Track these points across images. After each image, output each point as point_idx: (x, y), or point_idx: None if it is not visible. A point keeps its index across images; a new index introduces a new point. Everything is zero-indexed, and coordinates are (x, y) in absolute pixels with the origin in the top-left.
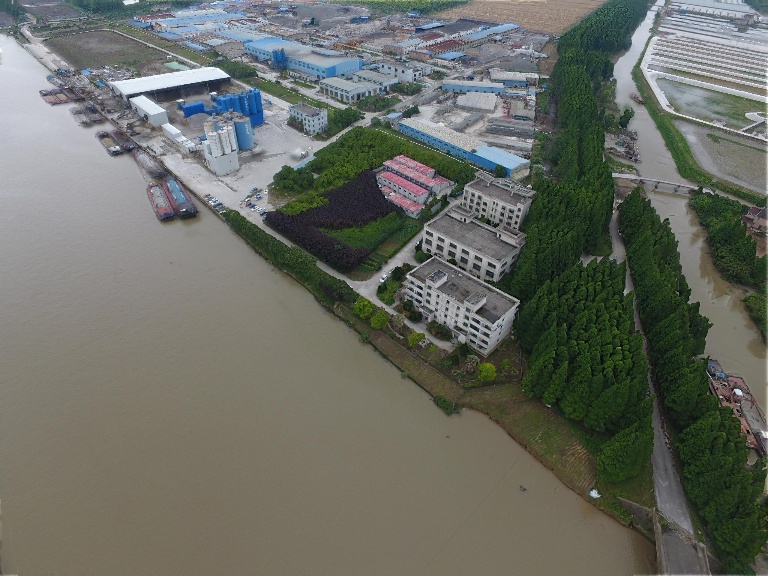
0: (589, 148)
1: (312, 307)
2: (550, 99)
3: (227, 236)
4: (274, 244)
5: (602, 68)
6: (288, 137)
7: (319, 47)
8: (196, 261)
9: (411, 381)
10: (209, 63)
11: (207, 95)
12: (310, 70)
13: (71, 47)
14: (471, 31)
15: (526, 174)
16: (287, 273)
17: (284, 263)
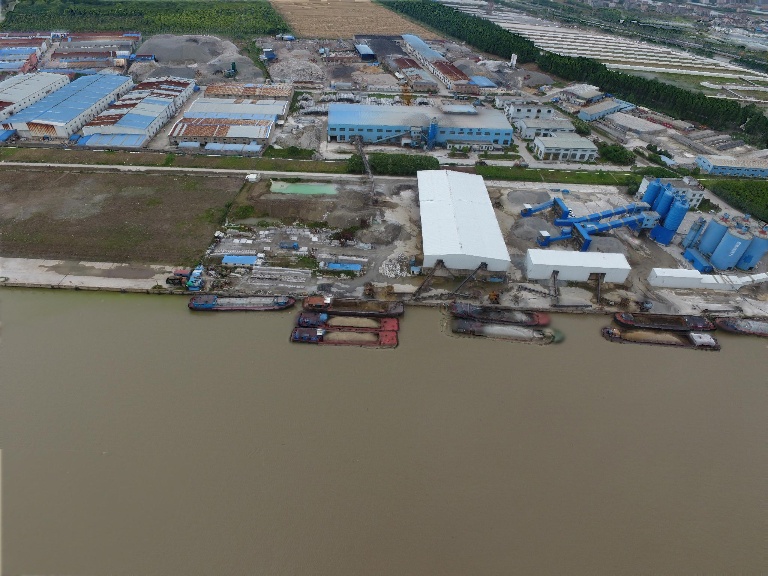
0: None
1: None
2: None
3: None
4: None
5: None
6: None
7: None
8: None
9: None
10: None
11: None
12: (482, 136)
13: None
14: None
15: None
16: None
17: None
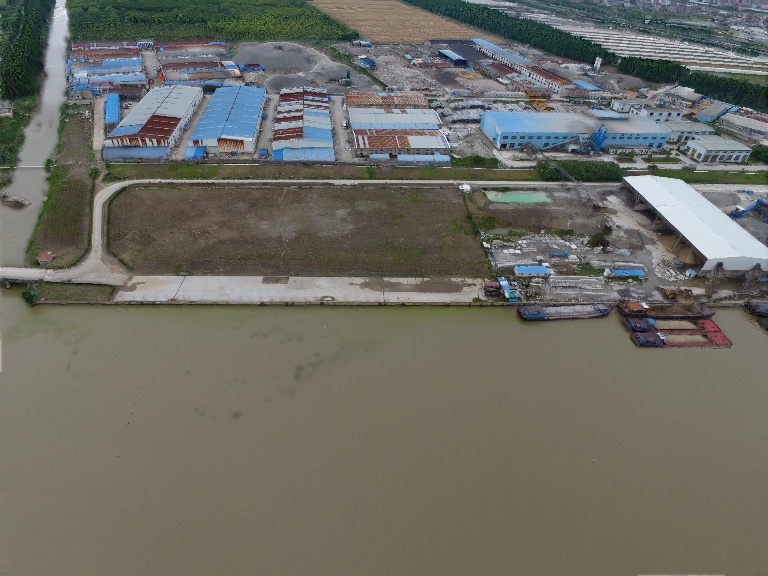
0: None
1: None
2: None
3: None
4: None
5: None
6: None
7: None
8: None
9: None
10: (565, 174)
11: None
12: (640, 140)
13: (255, 247)
14: None
15: None
16: None
17: None
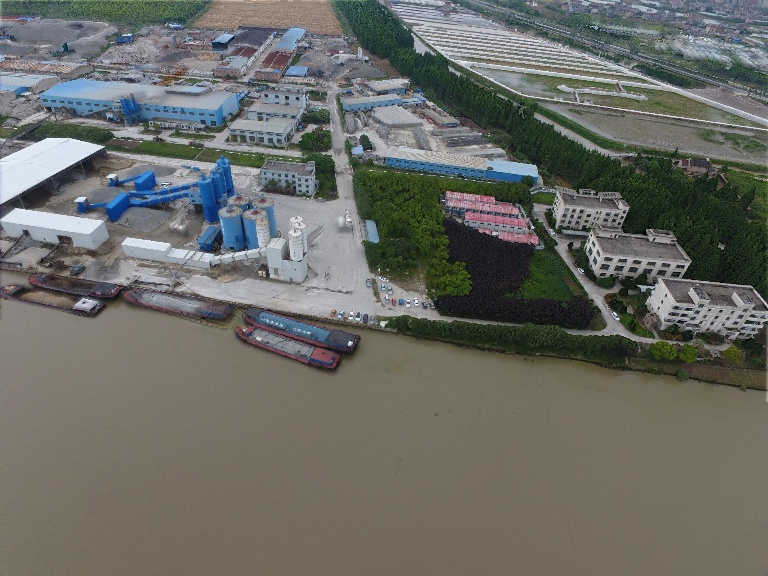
0: (567, 142)
1: (604, 375)
2: None
3: (420, 348)
4: (511, 332)
5: (444, 65)
6: (291, 206)
7: (128, 82)
8: (456, 393)
9: (752, 390)
10: None
11: (86, 180)
12: (187, 115)
13: None
14: (268, 40)
15: (541, 177)
16: (542, 355)
17: (537, 346)
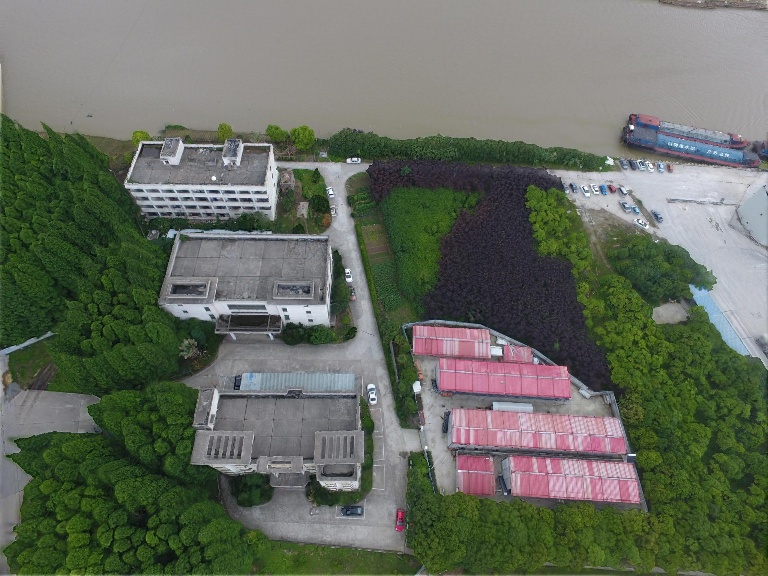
0: None
1: None
2: None
3: None
4: (473, 140)
5: None
6: None
7: None
8: (517, 104)
9: None
10: None
11: None
12: None
13: None
14: None
15: None
16: None
17: None
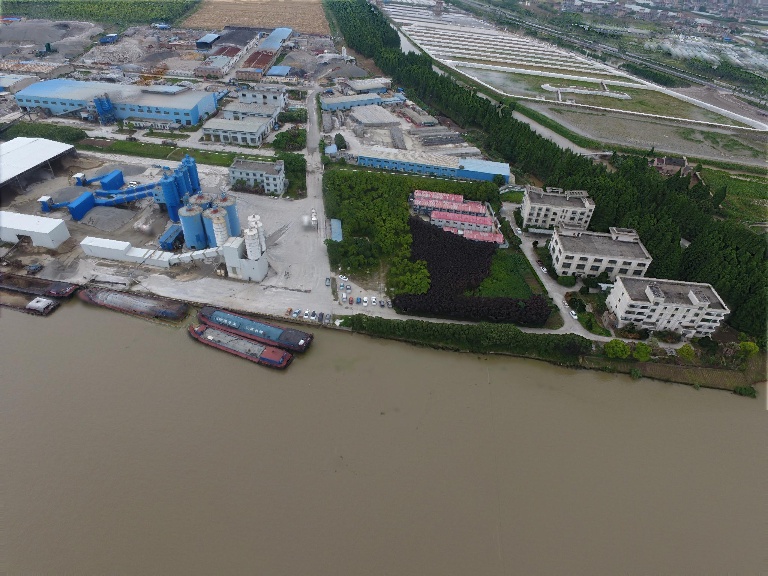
0: (541, 141)
1: (557, 373)
2: (421, 101)
3: (374, 347)
4: (465, 330)
5: (427, 64)
6: (258, 205)
7: (107, 81)
8: (404, 392)
9: (705, 388)
10: None
11: (54, 179)
12: (162, 115)
13: None
14: (254, 39)
15: (514, 176)
16: (496, 353)
17: (491, 345)
